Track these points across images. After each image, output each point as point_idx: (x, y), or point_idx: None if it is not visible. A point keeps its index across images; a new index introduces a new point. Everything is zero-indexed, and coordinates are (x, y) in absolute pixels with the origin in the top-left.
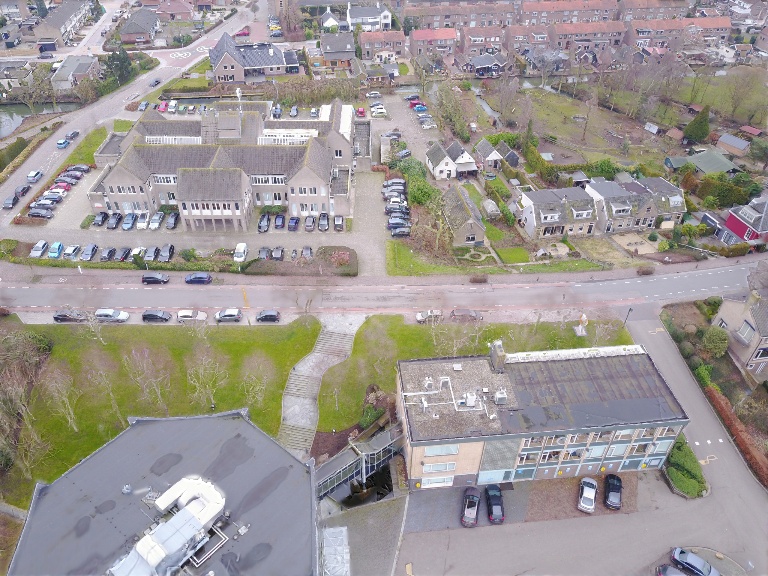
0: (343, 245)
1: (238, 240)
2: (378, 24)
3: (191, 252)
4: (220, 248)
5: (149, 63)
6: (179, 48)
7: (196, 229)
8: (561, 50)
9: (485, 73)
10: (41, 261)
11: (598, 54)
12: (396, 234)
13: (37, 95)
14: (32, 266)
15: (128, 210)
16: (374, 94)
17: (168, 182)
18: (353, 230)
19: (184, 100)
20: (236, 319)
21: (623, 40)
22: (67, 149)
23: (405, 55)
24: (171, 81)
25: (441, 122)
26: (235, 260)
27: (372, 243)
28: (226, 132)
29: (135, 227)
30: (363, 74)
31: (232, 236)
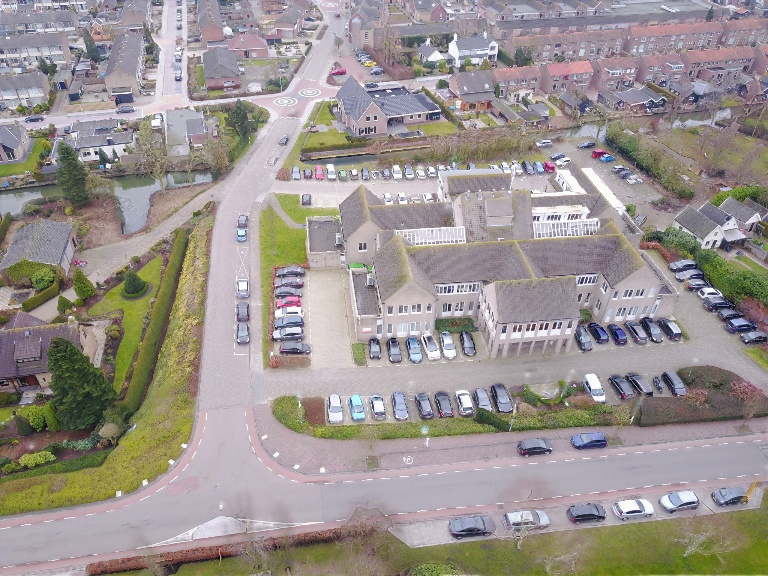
0: (701, 362)
1: (567, 365)
2: (486, 56)
3: None
4: (554, 380)
5: (260, 114)
6: (278, 93)
7: (506, 354)
8: (693, 79)
9: (638, 110)
10: (362, 432)
11: (748, 84)
12: (751, 341)
13: (150, 164)
14: (352, 441)
15: (402, 332)
16: (546, 143)
17: (449, 292)
18: (691, 338)
19: (327, 160)
20: (695, 507)
21: (752, 66)
22: (250, 242)
23: (538, 92)
24: (301, 137)
25: (641, 174)
26: (596, 400)
27: (732, 356)
28: (497, 219)
29: (424, 357)
30: (521, 119)
31: (555, 360)
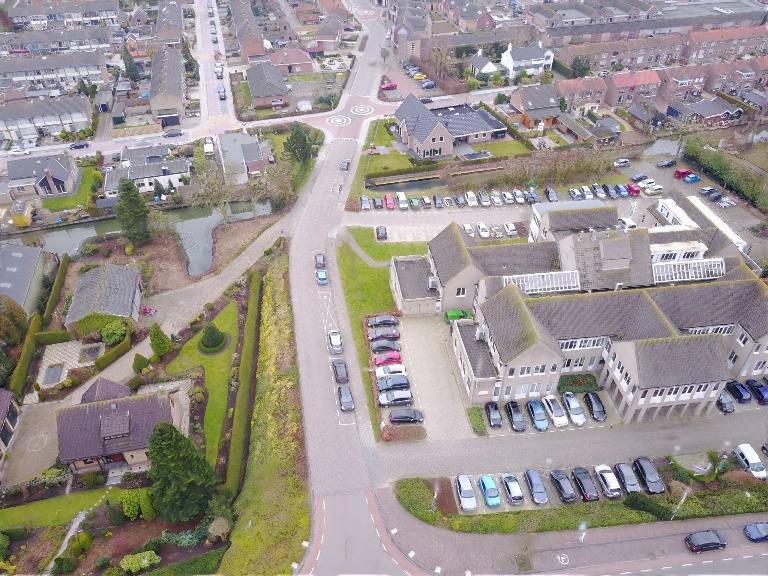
0: None
1: (710, 431)
2: (541, 66)
3: (677, 466)
4: (701, 450)
5: (315, 136)
6: (329, 111)
7: None
8: (763, 87)
9: (713, 123)
10: (505, 524)
11: None
12: None
13: (208, 194)
14: (496, 535)
15: (521, 394)
16: (624, 162)
17: (571, 347)
18: None
19: (393, 186)
20: None
21: None
22: (331, 285)
23: (602, 105)
24: (362, 160)
25: (732, 196)
26: (757, 477)
27: None
28: (614, 262)
29: (549, 423)
30: (593, 136)
31: (695, 424)
